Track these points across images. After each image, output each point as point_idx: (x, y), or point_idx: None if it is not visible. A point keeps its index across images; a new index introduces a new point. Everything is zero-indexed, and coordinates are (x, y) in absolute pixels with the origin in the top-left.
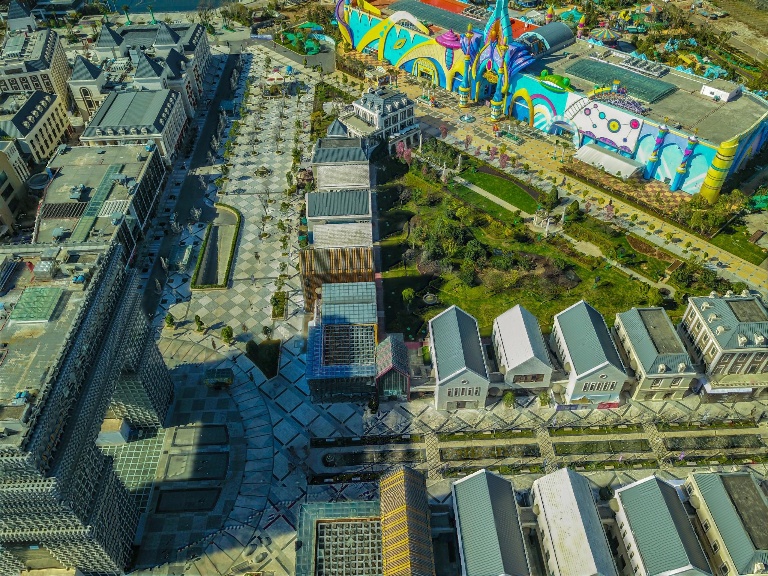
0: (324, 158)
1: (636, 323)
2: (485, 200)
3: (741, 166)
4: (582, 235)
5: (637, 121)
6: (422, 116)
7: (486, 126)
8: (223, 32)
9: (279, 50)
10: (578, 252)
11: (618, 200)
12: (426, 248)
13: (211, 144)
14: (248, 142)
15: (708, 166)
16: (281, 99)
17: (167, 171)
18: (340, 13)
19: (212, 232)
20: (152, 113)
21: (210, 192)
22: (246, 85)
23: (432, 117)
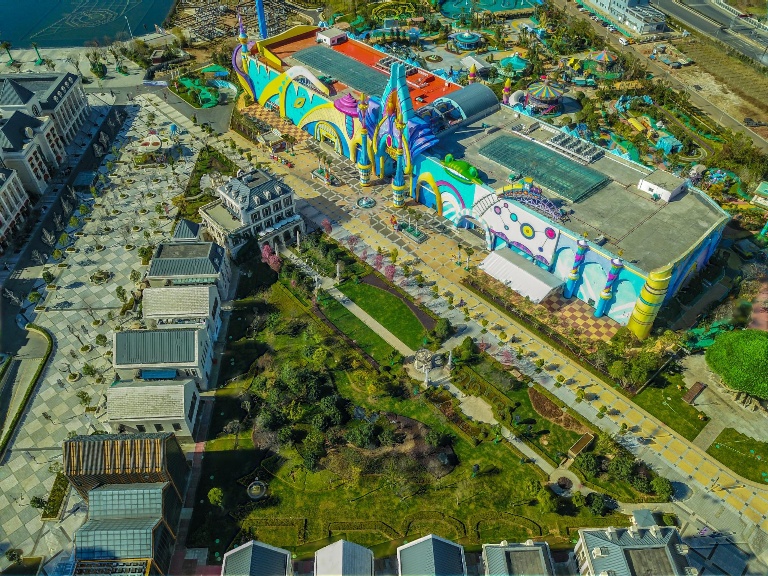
0: (163, 270)
1: (501, 574)
2: (362, 327)
3: (684, 284)
4: (473, 386)
5: (553, 230)
6: (313, 197)
7: (386, 214)
8: (115, 75)
9: (172, 101)
10: (463, 415)
11: (527, 330)
12: (262, 412)
13: (42, 239)
14: (97, 231)
15: (636, 296)
16: (154, 169)
17: None
18: (238, 61)
19: (11, 369)
20: None
21: (28, 306)
22: (113, 152)
23: (325, 199)
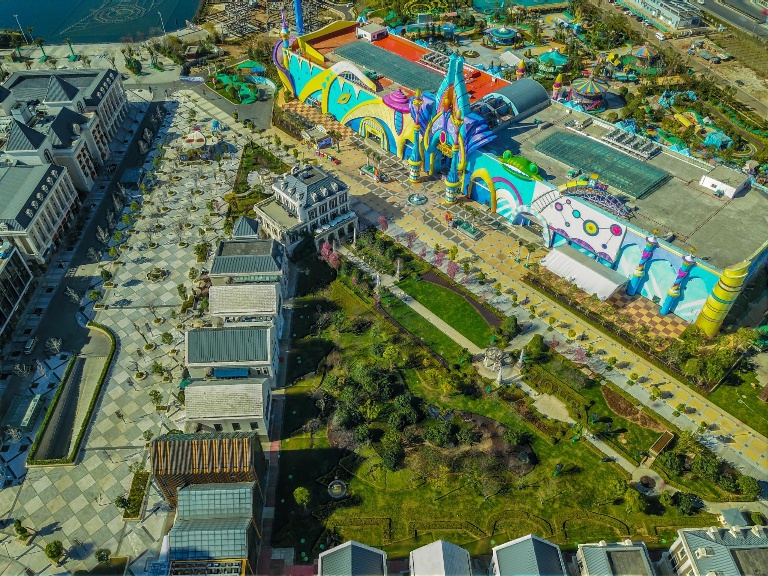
0: (225, 268)
1: (604, 574)
2: (426, 325)
3: (749, 281)
4: (545, 384)
5: (619, 227)
6: (364, 194)
7: (439, 210)
8: (150, 71)
9: (210, 97)
10: (538, 413)
11: (594, 327)
12: (338, 410)
13: (96, 236)
14: (148, 228)
15: (708, 293)
16: (200, 166)
17: (40, 270)
18: (278, 57)
19: (76, 368)
20: (19, 201)
21: (87, 304)
22: (158, 148)
23: (375, 196)
